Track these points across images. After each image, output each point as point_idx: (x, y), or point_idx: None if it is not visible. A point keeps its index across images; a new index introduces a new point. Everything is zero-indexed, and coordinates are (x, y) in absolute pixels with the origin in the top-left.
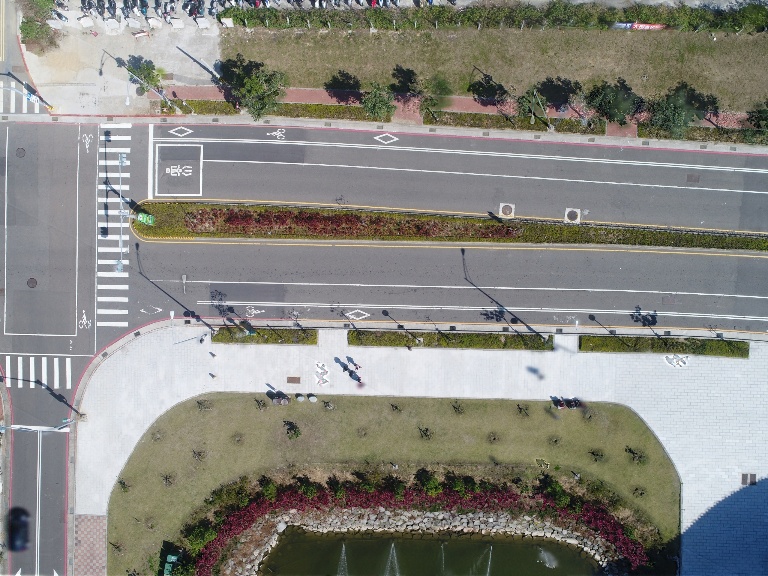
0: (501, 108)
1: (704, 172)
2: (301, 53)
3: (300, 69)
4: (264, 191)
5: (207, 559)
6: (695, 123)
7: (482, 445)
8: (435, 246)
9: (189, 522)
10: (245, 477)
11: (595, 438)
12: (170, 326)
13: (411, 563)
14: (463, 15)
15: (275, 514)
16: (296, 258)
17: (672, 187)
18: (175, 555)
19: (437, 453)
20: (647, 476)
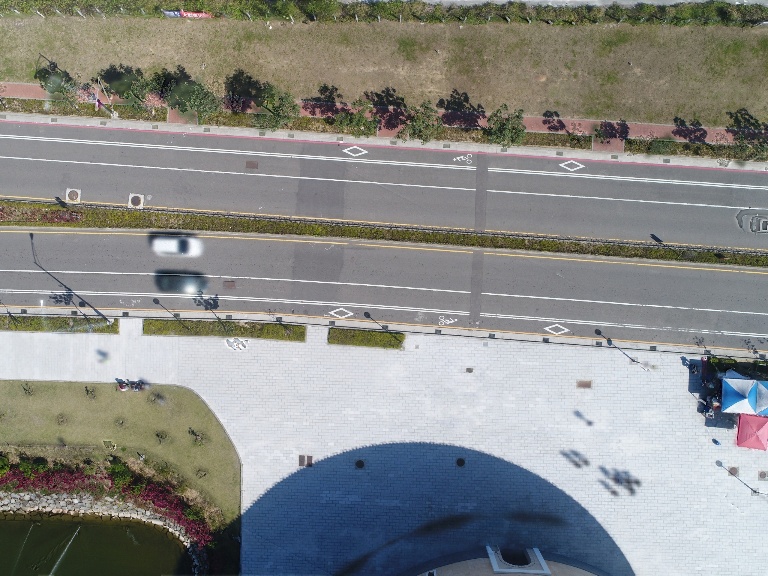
0: (67, 95)
1: (262, 158)
2: None
3: None
4: None
5: None
6: (253, 110)
7: (51, 426)
8: (4, 230)
9: None
10: None
11: (160, 420)
12: None
13: (0, 543)
14: (26, 3)
15: None
16: None
17: (231, 173)
18: None
19: (8, 434)
20: (209, 457)
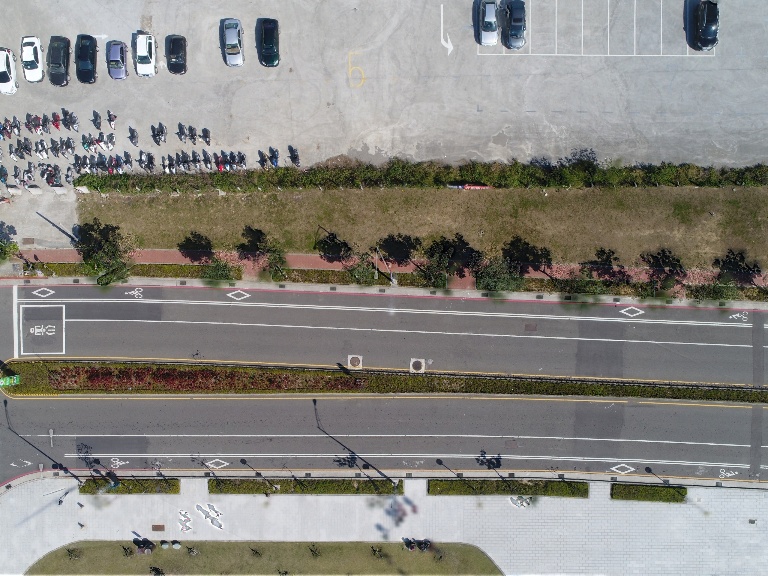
0: (346, 264)
1: (541, 321)
2: (154, 216)
3: (154, 231)
4: (124, 348)
5: None
6: (530, 275)
7: None
8: (288, 397)
9: None
10: None
11: None
12: (39, 478)
13: None
14: (306, 178)
15: None
16: (157, 411)
17: (511, 336)
18: None
19: None
20: None
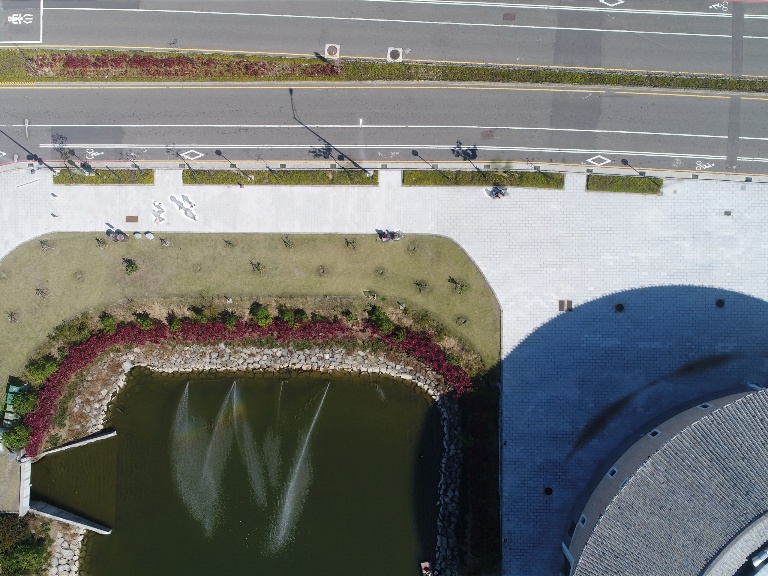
0: None
1: (520, 10)
2: None
3: None
4: (101, 37)
5: (49, 391)
6: None
7: (312, 278)
8: (264, 86)
9: (33, 357)
10: (86, 313)
11: (419, 269)
12: (14, 169)
13: (252, 400)
14: None
15: (119, 352)
16: (132, 101)
17: (489, 25)
18: (17, 386)
19: (269, 286)
20: (469, 305)
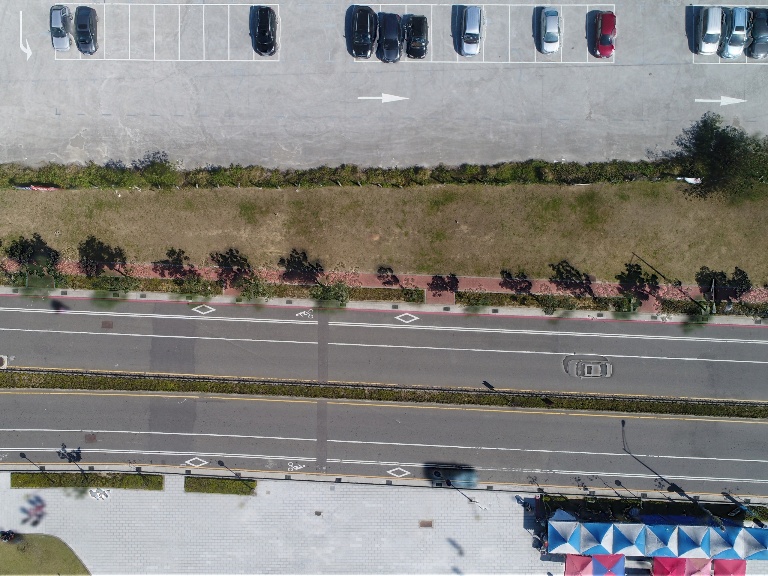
0: None
1: (117, 319)
2: None
3: None
4: None
5: None
6: (106, 274)
7: None
8: None
9: None
10: None
11: (30, 567)
12: None
13: None
14: None
15: None
16: None
17: (88, 333)
18: None
19: None
20: None
